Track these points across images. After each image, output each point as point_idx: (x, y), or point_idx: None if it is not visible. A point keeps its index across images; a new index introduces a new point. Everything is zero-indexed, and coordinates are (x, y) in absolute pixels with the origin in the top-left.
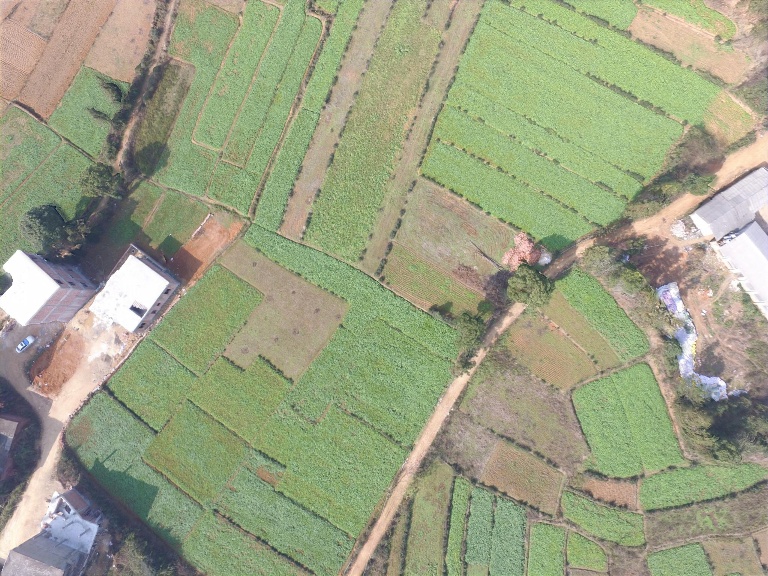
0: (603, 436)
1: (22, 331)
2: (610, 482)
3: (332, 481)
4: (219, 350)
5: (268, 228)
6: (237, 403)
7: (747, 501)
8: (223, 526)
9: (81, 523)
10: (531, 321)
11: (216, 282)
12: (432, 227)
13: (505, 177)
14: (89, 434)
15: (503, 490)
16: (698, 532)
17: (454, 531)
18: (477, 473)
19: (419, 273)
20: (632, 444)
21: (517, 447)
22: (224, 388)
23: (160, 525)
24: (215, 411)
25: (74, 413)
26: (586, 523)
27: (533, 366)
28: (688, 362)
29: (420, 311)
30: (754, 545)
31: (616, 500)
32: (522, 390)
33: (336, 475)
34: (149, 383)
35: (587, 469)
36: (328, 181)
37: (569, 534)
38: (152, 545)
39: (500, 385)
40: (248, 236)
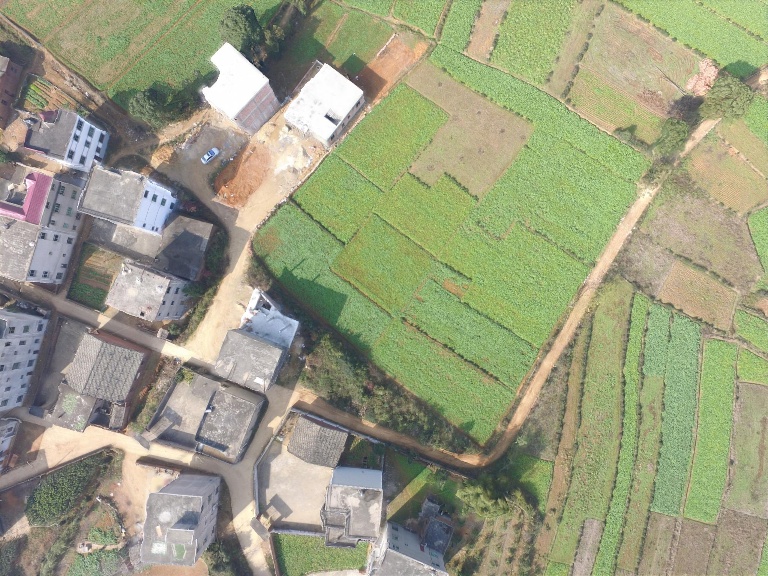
0: None
1: (206, 143)
2: None
3: (516, 294)
4: (405, 167)
5: (455, 48)
6: (424, 218)
7: None
8: (411, 333)
9: (282, 319)
10: (712, 146)
11: (402, 100)
12: (618, 52)
13: (692, 4)
14: (277, 244)
15: (679, 307)
16: None
17: (633, 344)
18: (655, 291)
19: (605, 96)
20: None
21: (694, 267)
22: (410, 203)
23: (349, 331)
24: (402, 225)
25: (262, 223)
26: (757, 339)
27: (712, 189)
28: None
29: (605, 133)
30: None
31: None
32: (700, 213)
33: (520, 289)
34: (336, 196)
35: (760, 289)
36: (515, 4)
37: (739, 350)
38: (345, 347)
39: (679, 207)
40: (434, 56)
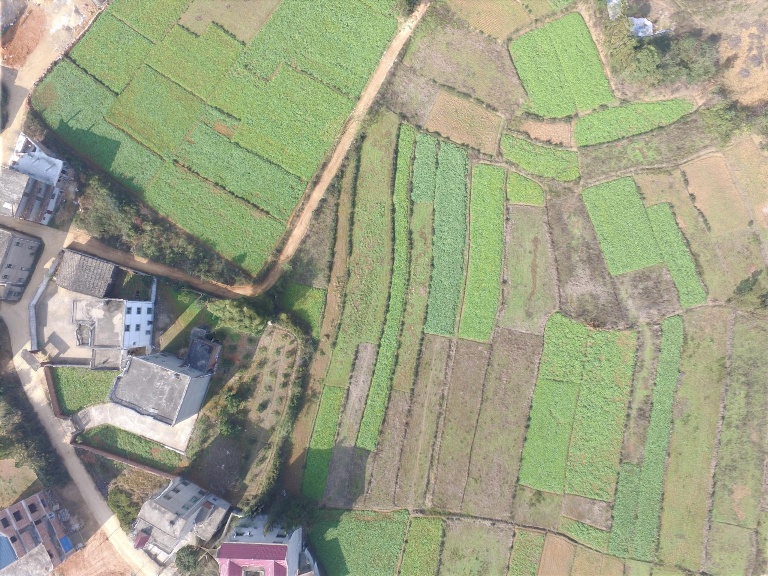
0: (538, 81)
1: None
2: (546, 123)
3: (284, 131)
4: (174, 19)
5: None
6: (193, 65)
7: (674, 134)
8: (182, 174)
9: (46, 159)
10: None
11: None
12: None
13: None
14: (53, 99)
15: (446, 135)
16: (629, 165)
17: (400, 172)
18: (421, 121)
19: None
20: (566, 86)
21: (458, 95)
22: (180, 52)
23: (123, 175)
24: (172, 73)
25: (38, 80)
26: (524, 161)
27: (471, 19)
28: (616, 4)
29: None
30: (681, 176)
31: (552, 139)
32: (462, 42)
33: (288, 126)
34: (109, 50)
35: (524, 112)
36: None
37: (509, 174)
38: (115, 187)
39: (441, 39)
40: None
